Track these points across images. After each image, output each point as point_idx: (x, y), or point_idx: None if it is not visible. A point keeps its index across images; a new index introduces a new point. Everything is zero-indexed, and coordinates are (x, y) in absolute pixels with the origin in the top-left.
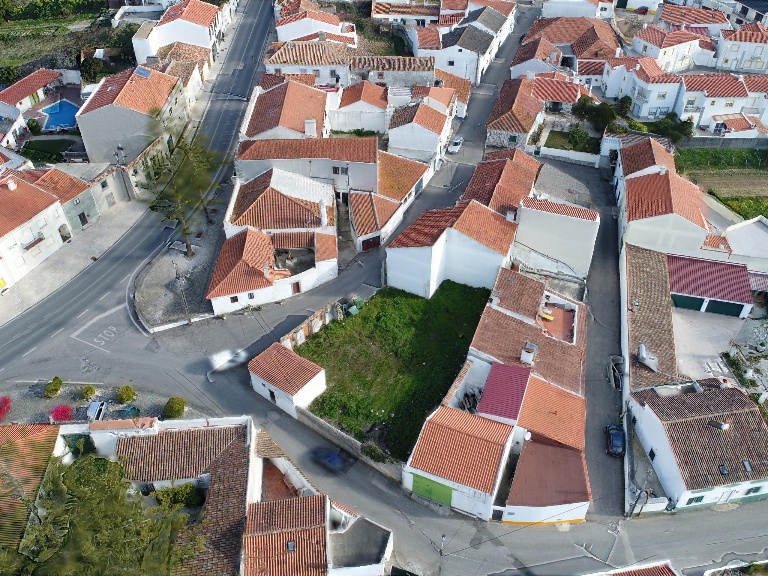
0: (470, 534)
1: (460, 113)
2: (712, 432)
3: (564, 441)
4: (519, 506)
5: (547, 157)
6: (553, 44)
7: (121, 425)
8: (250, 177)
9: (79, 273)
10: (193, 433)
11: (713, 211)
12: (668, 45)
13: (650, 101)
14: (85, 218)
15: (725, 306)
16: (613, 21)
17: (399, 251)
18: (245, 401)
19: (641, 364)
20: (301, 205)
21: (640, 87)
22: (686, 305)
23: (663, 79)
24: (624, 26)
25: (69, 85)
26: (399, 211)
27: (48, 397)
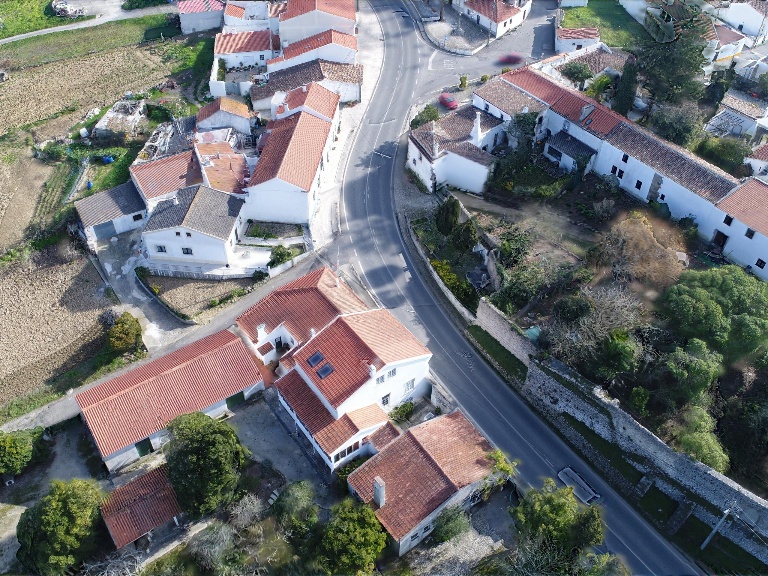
0: None
1: None
2: (765, 3)
3: None
4: (727, 45)
5: None
6: None
7: (555, 58)
8: None
9: (384, 48)
10: (583, 57)
11: None
12: None
13: None
14: None
15: None
16: None
17: None
18: None
19: None
20: None
21: None
22: None
23: None
24: None
25: None
26: None
27: (462, 90)
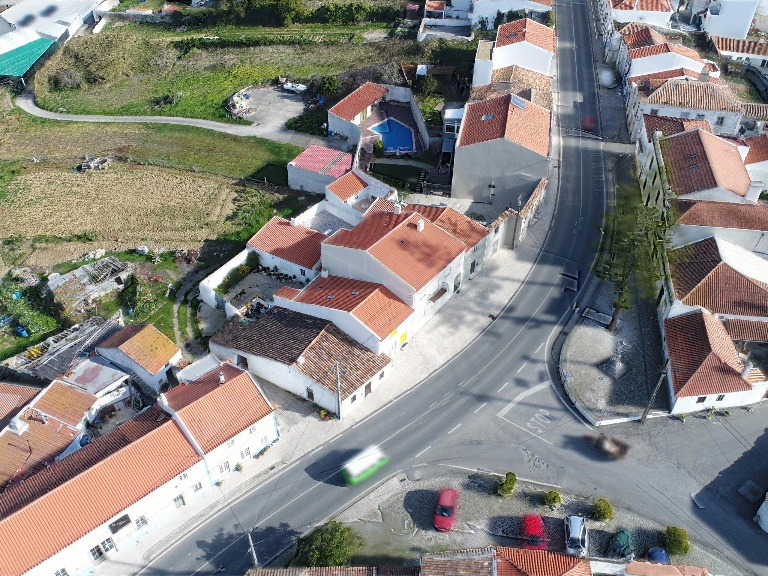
0: None
1: None
2: None
3: None
4: None
5: None
6: None
7: (666, 573)
8: (680, 243)
9: (480, 333)
10: None
11: None
12: None
13: None
14: (473, 266)
15: None
16: None
17: None
18: (757, 543)
19: None
20: (762, 288)
21: None
22: None
23: None
24: None
25: (392, 102)
26: None
27: (498, 495)
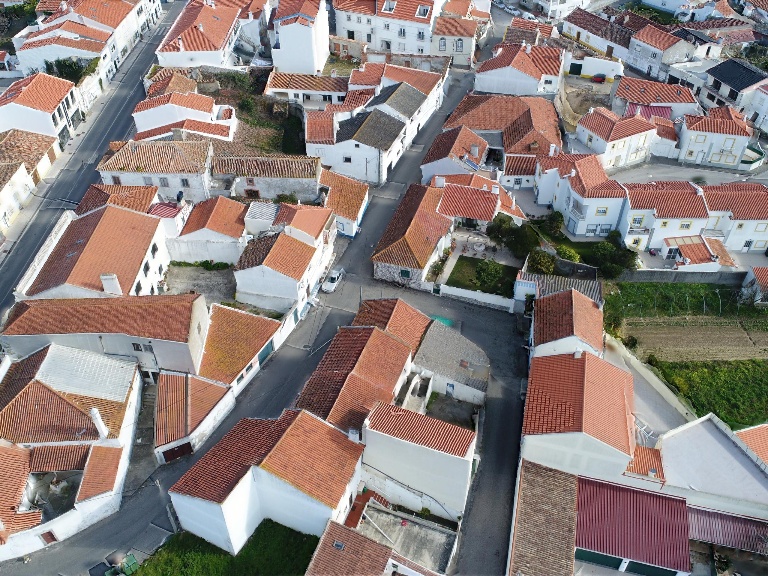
0: None
1: (348, 231)
2: None
3: None
4: None
5: (449, 297)
6: (480, 131)
7: None
8: (23, 354)
9: None
10: None
11: (653, 390)
12: (617, 137)
13: (587, 217)
14: None
15: (652, 569)
16: (559, 97)
17: (183, 499)
18: None
19: None
20: (74, 406)
21: (575, 200)
22: (599, 561)
23: (602, 192)
24: (575, 99)
25: None
26: (225, 399)
27: None
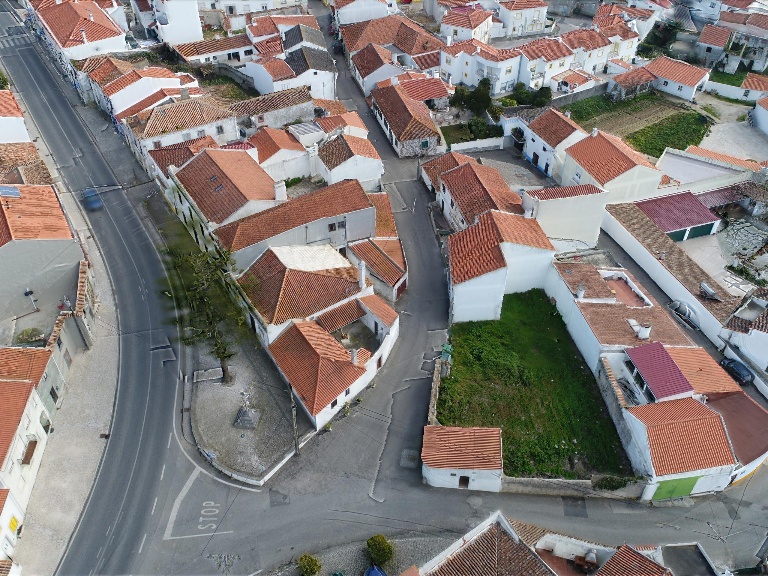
0: (723, 509)
1: None
2: None
3: (727, 390)
4: (751, 462)
5: None
6: None
7: None
8: (244, 267)
9: (100, 462)
10: (455, 561)
11: None
12: (476, 25)
13: (501, 78)
14: (54, 393)
15: (701, 229)
16: None
17: (470, 283)
18: (435, 502)
19: (709, 300)
20: (330, 276)
21: (489, 67)
22: (673, 240)
23: (507, 55)
24: None
25: None
26: None
27: None
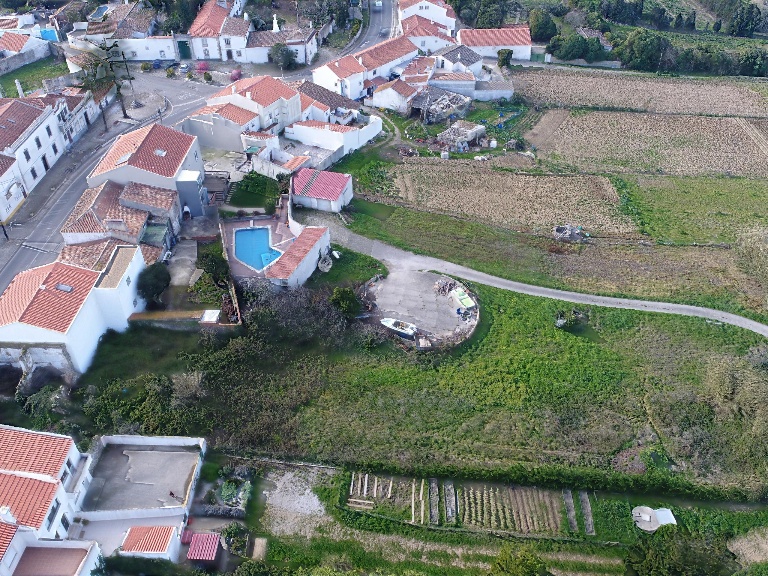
0: None
1: None
2: None
3: None
4: None
5: None
6: None
7: None
8: None
9: None
10: None
11: None
12: None
13: None
14: None
15: None
16: None
17: None
18: None
19: None
20: None
21: None
22: None
23: None
24: None
25: None
26: None
27: (213, 80)
